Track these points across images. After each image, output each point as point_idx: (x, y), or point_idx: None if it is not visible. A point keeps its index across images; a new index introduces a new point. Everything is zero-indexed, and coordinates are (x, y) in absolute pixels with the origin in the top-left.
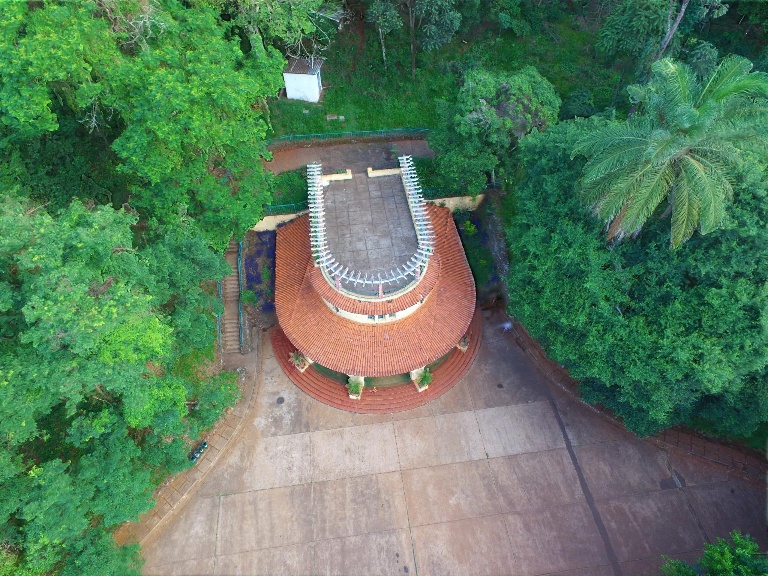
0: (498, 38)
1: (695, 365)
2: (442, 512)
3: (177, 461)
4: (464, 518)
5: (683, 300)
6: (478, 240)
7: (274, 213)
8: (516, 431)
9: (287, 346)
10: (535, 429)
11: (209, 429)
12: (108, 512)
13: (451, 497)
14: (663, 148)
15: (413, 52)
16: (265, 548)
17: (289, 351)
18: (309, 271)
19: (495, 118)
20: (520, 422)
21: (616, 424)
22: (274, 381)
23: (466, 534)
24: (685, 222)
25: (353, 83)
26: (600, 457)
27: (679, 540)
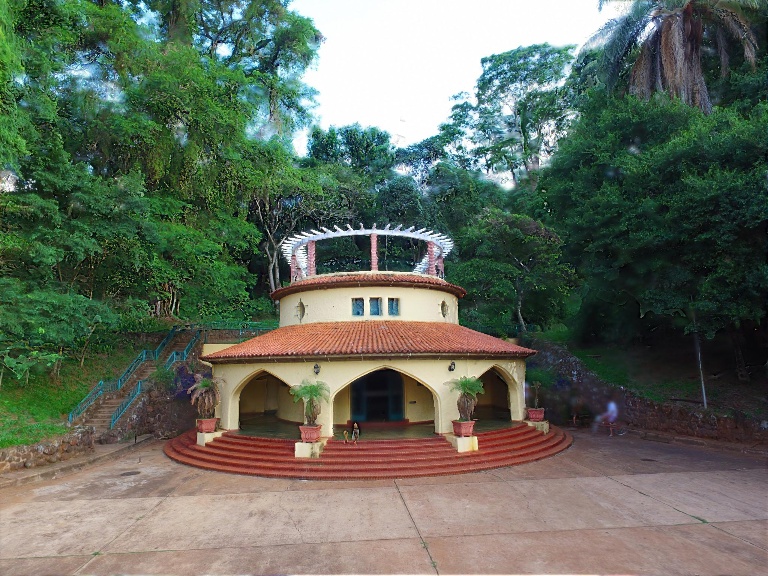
0: None
1: None
2: None
3: None
4: None
5: None
6: None
7: None
8: (748, 492)
9: (194, 432)
10: None
11: None
12: None
13: None
14: None
15: None
16: None
17: (194, 434)
18: None
19: None
20: (745, 484)
21: None
22: (137, 462)
23: None
24: None
25: None
26: None
27: None
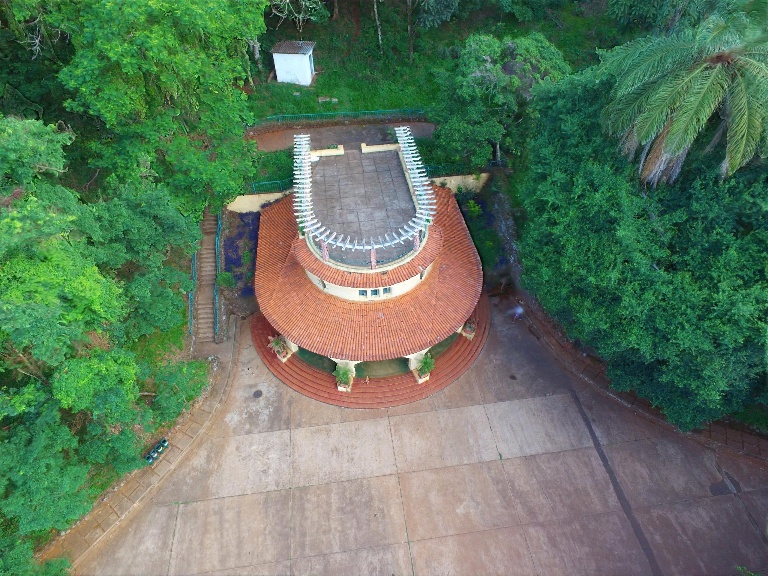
0: (499, 23)
1: (761, 323)
2: (448, 523)
3: (125, 457)
4: (475, 530)
5: (738, 249)
6: (483, 221)
7: (258, 192)
8: (534, 428)
9: (268, 334)
10: (556, 425)
11: (171, 425)
12: (24, 514)
13: (458, 505)
14: (720, 32)
15: (410, 34)
16: (230, 568)
17: None
18: (293, 243)
19: (501, 75)
20: (538, 417)
21: (651, 419)
22: (251, 373)
23: (478, 550)
24: (745, 137)
25: (347, 67)
26: (635, 457)
27: (741, 557)
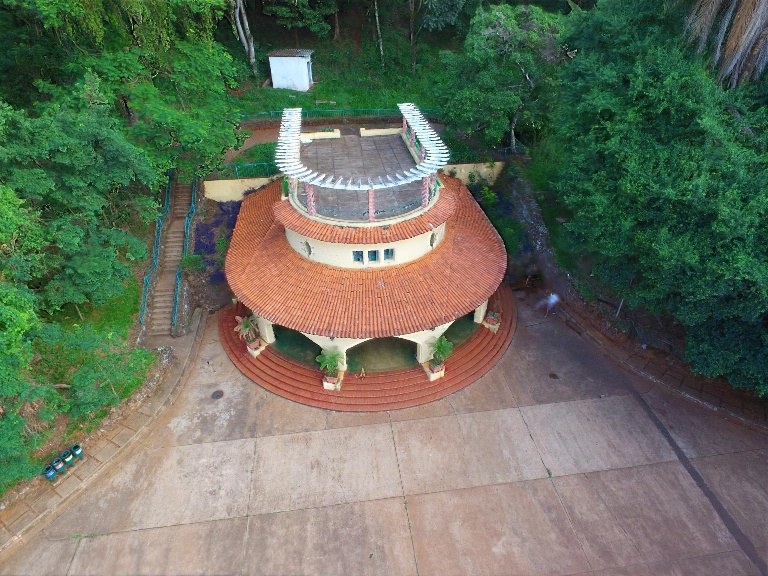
0: None
1: None
2: (481, 568)
3: (1, 454)
4: None
5: None
6: (500, 210)
7: (241, 176)
8: (590, 436)
9: None
10: (620, 433)
11: (92, 428)
12: None
13: (495, 541)
14: None
15: (413, 43)
16: None
17: None
18: None
19: (517, 30)
20: (594, 423)
21: (749, 426)
22: (213, 370)
23: None
24: None
25: (347, 77)
26: (741, 475)
27: None
